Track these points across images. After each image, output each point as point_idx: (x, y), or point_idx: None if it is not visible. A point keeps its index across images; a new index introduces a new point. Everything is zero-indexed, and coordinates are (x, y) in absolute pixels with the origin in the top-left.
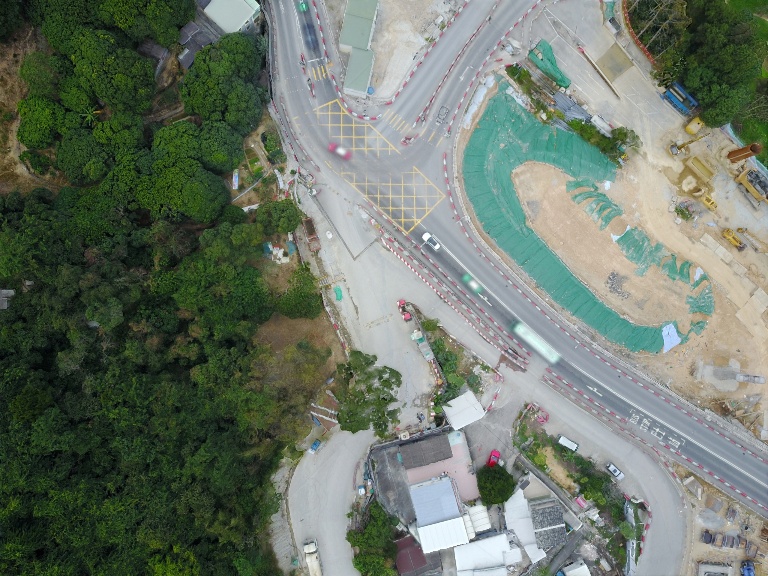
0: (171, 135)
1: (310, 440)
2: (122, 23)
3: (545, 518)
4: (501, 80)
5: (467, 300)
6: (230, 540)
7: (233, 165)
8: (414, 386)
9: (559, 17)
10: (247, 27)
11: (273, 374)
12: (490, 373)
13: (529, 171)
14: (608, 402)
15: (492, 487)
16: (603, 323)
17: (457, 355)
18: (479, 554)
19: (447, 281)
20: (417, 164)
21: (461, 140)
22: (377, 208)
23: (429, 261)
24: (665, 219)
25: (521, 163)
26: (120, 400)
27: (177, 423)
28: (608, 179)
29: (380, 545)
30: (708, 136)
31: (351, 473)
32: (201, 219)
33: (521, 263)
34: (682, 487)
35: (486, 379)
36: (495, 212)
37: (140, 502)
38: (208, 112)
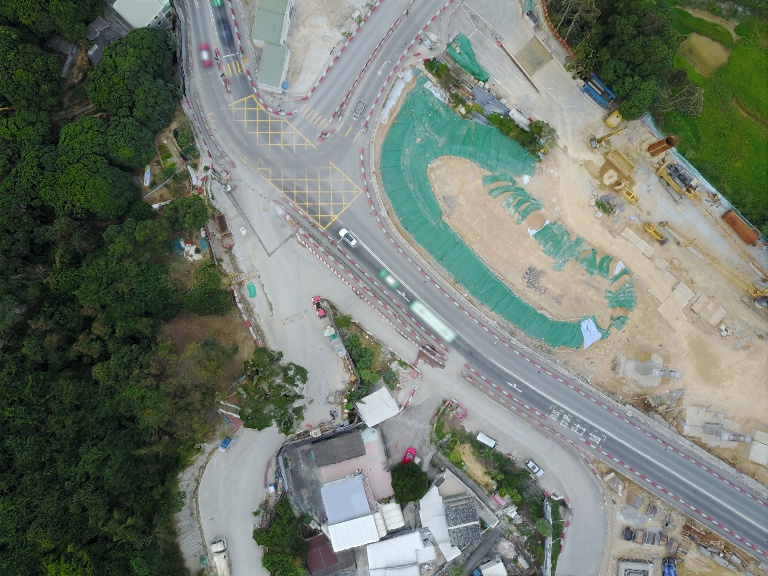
0: (76, 131)
1: (221, 438)
2: (25, 19)
3: (458, 515)
4: (419, 74)
5: (385, 296)
6: None
7: (142, 161)
8: (328, 383)
9: (477, 10)
10: (158, 22)
11: (172, 371)
12: (408, 369)
13: (445, 165)
14: (528, 398)
15: (404, 484)
16: (522, 318)
17: (374, 351)
18: (392, 552)
19: (364, 277)
20: (334, 159)
21: (379, 135)
22: (293, 204)
23: (346, 257)
24: (585, 213)
25: (436, 157)
26: (16, 398)
27: (74, 421)
28: (527, 173)
29: (285, 543)
30: (629, 129)
31: (262, 471)
32: (107, 216)
33: (439, 258)
34: (602, 483)
35: (404, 376)
36: (412, 207)
37: (32, 501)
38: (115, 108)
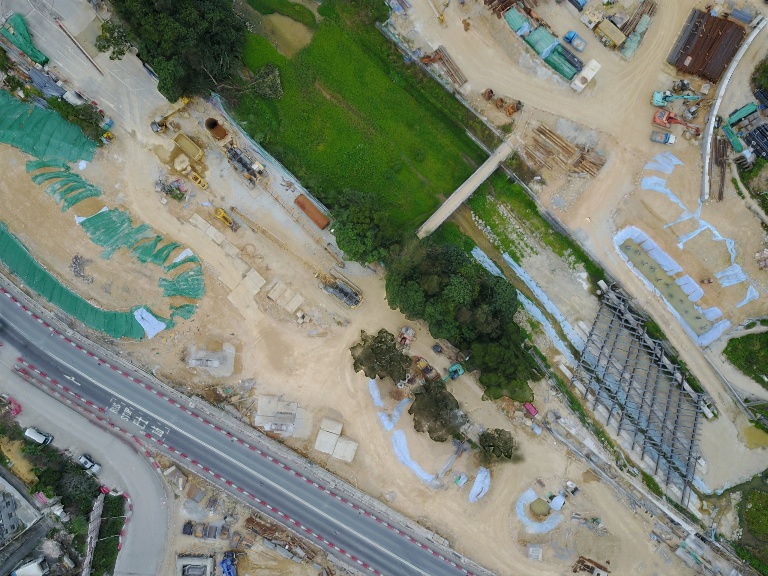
0: None
1: None
2: None
3: None
4: None
5: None
6: None
7: None
8: None
9: None
10: None
11: None
12: None
13: None
14: (87, 391)
15: None
16: (77, 309)
17: None
18: None
19: None
20: None
21: None
22: None
23: None
24: (152, 199)
25: None
26: None
27: None
28: (83, 158)
29: None
30: (199, 112)
31: None
32: None
33: None
34: (162, 477)
35: None
36: None
37: None
38: None
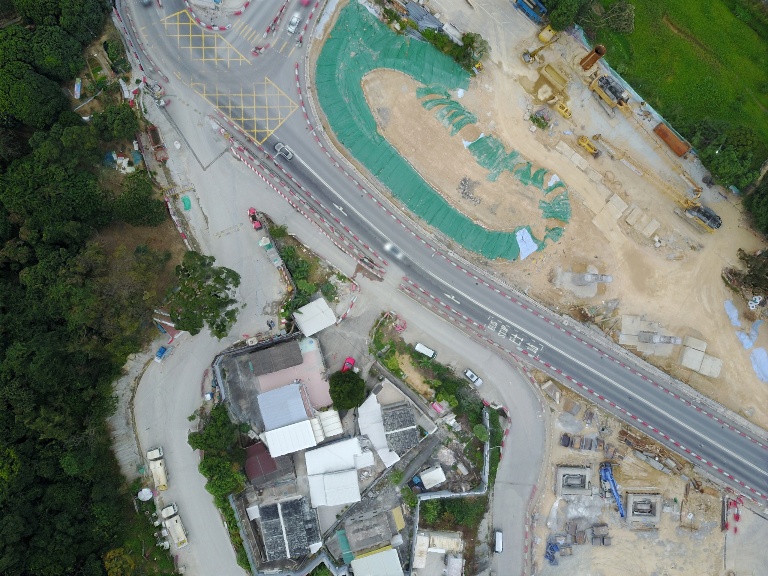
0: None
1: (156, 349)
2: None
3: (395, 420)
4: None
5: (322, 210)
6: (58, 441)
7: (71, 71)
8: (264, 294)
9: None
10: None
11: (99, 271)
12: (346, 283)
13: (379, 78)
14: (466, 309)
15: (341, 390)
16: (458, 230)
17: (311, 264)
18: (330, 458)
19: (301, 191)
20: (269, 74)
21: (314, 50)
22: (228, 119)
23: (282, 171)
24: (520, 127)
25: (370, 70)
26: None
27: None
28: (461, 87)
29: (220, 446)
30: (562, 45)
31: (199, 381)
32: (34, 123)
33: (376, 173)
34: (540, 391)
35: (342, 288)
36: (348, 121)
37: None
38: (41, 16)
